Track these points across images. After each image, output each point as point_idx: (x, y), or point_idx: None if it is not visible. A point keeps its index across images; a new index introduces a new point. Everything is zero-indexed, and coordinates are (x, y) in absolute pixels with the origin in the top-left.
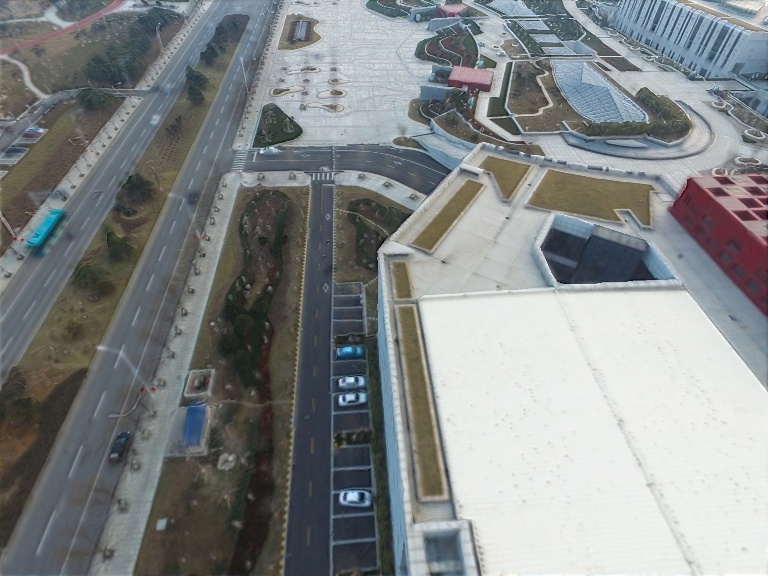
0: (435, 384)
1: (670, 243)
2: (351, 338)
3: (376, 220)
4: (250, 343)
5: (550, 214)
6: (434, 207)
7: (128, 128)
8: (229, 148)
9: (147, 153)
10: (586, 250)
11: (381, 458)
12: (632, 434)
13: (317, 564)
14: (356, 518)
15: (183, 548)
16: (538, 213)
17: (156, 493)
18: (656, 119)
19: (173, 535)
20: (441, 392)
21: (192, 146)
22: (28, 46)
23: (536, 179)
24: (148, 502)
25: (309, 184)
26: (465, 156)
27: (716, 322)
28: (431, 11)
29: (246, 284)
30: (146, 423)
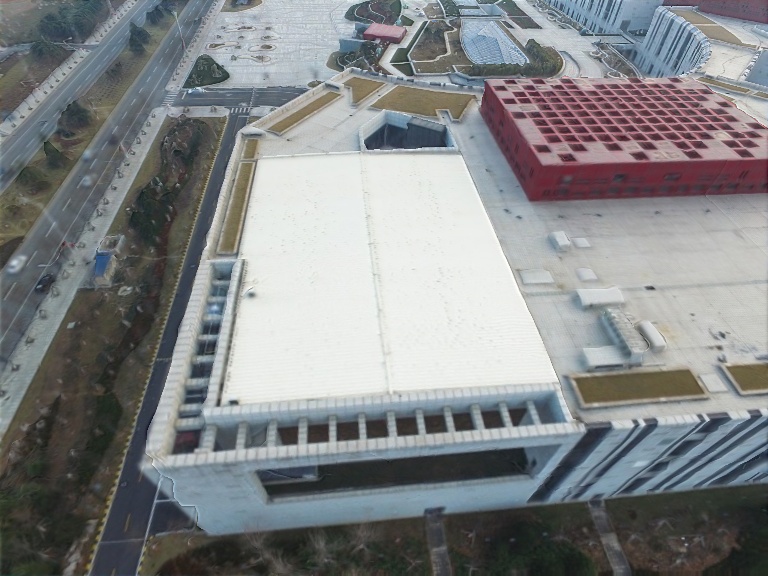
0: (251, 201)
1: (469, 130)
2: None
3: None
4: (155, 219)
5: (381, 111)
6: (295, 108)
7: (75, 74)
8: (162, 89)
9: (89, 92)
10: (407, 137)
11: None
12: (373, 222)
13: None
14: None
15: (85, 336)
16: (376, 112)
17: (69, 308)
18: None
19: (79, 331)
20: (253, 204)
21: (130, 87)
22: None
23: (386, 92)
24: (63, 314)
25: (227, 115)
26: None
27: (474, 173)
28: None
29: (159, 183)
30: (66, 267)
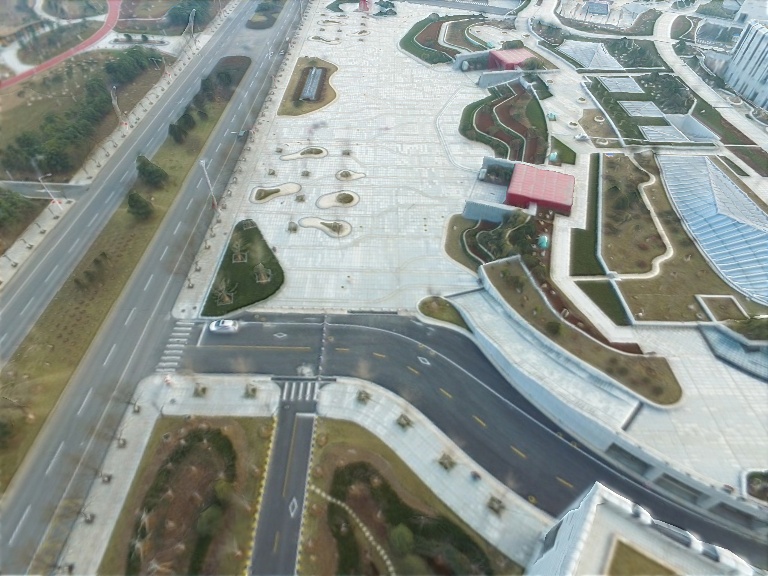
0: None
1: None
2: None
3: (376, 530)
4: None
5: None
6: None
7: (34, 262)
8: (167, 314)
9: (40, 323)
10: None
11: None
12: None
13: None
14: None
15: None
16: None
17: None
18: None
19: None
20: None
21: (112, 308)
22: None
23: None
24: None
25: (274, 411)
26: (568, 556)
27: None
28: (482, 57)
29: None
30: None
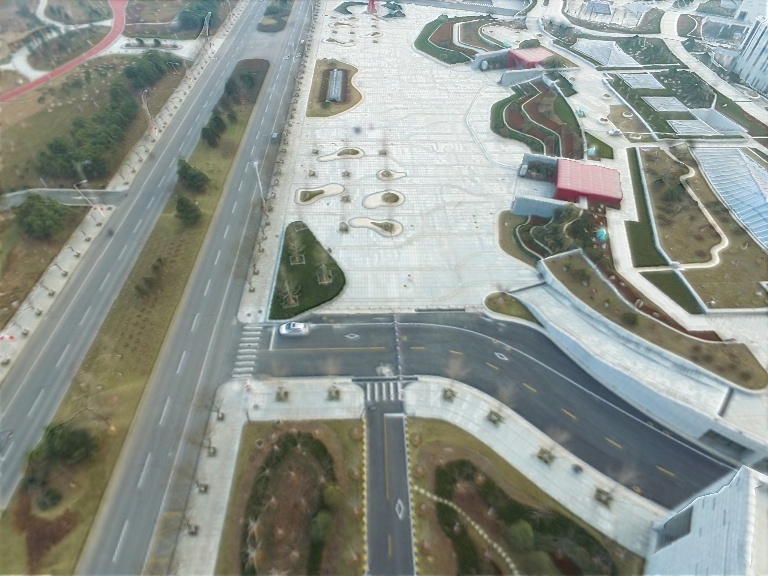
0: None
1: None
2: None
3: (490, 528)
4: None
5: None
6: None
7: (84, 270)
8: (232, 318)
9: (103, 332)
10: None
11: None
12: None
13: None
14: None
15: None
16: None
17: None
18: None
19: None
20: None
21: (175, 314)
22: None
23: None
24: None
25: (362, 413)
26: (743, 540)
27: None
28: (501, 57)
29: None
30: None
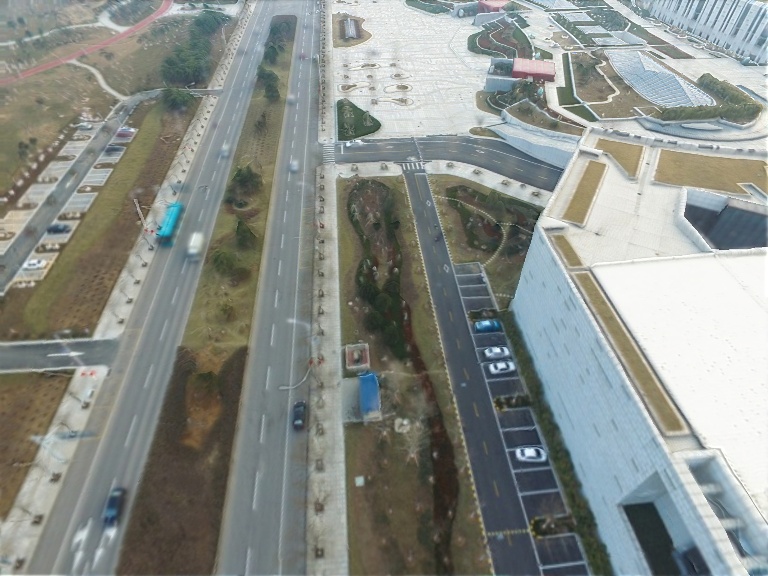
0: (637, 338)
1: None
2: (485, 313)
3: (476, 205)
4: (394, 319)
5: (682, 189)
6: (568, 186)
7: (213, 126)
8: (315, 142)
9: (239, 149)
10: (719, 221)
11: (549, 418)
12: None
13: (511, 512)
14: (534, 472)
15: (387, 501)
16: (667, 189)
17: (346, 454)
18: (723, 103)
19: (373, 490)
20: (646, 345)
21: (280, 141)
22: (94, 50)
23: (652, 158)
24: (341, 462)
25: (402, 173)
26: (580, 139)
27: None
28: (473, 6)
29: (371, 267)
30: (319, 393)
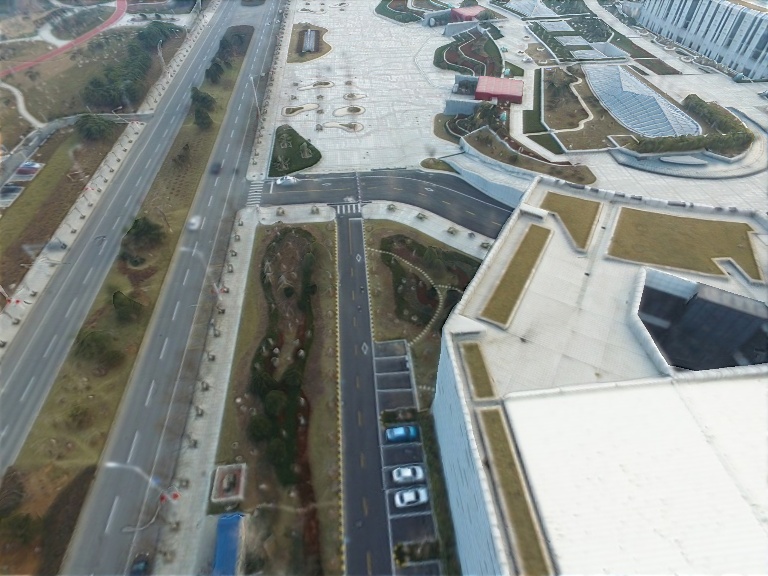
0: (549, 534)
1: None
2: (401, 415)
3: (413, 261)
4: (284, 427)
5: (640, 269)
6: (498, 263)
7: (131, 159)
8: (243, 178)
9: (153, 188)
10: (687, 313)
11: None
12: None
13: None
14: None
15: None
16: (622, 266)
17: None
18: (710, 130)
19: None
20: (559, 548)
21: (202, 178)
22: (22, 69)
23: (609, 220)
24: None
25: (334, 219)
26: (523, 194)
27: None
28: (446, 15)
29: (274, 347)
30: (168, 541)
